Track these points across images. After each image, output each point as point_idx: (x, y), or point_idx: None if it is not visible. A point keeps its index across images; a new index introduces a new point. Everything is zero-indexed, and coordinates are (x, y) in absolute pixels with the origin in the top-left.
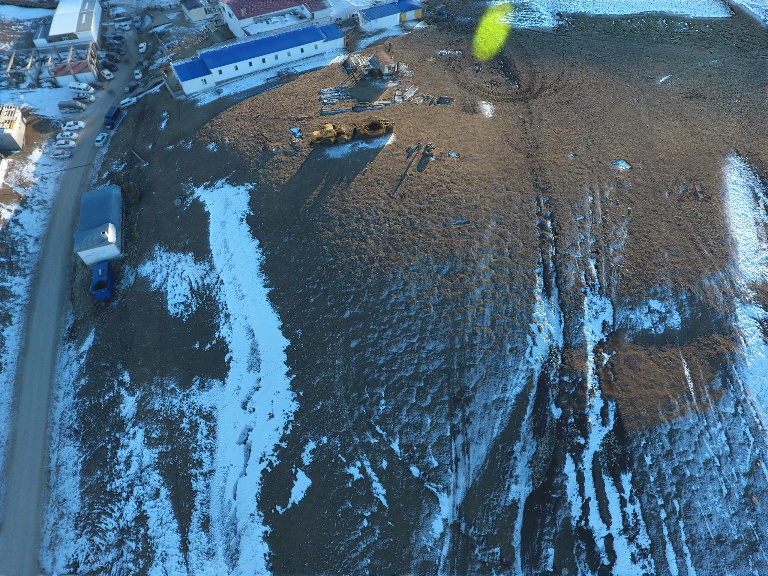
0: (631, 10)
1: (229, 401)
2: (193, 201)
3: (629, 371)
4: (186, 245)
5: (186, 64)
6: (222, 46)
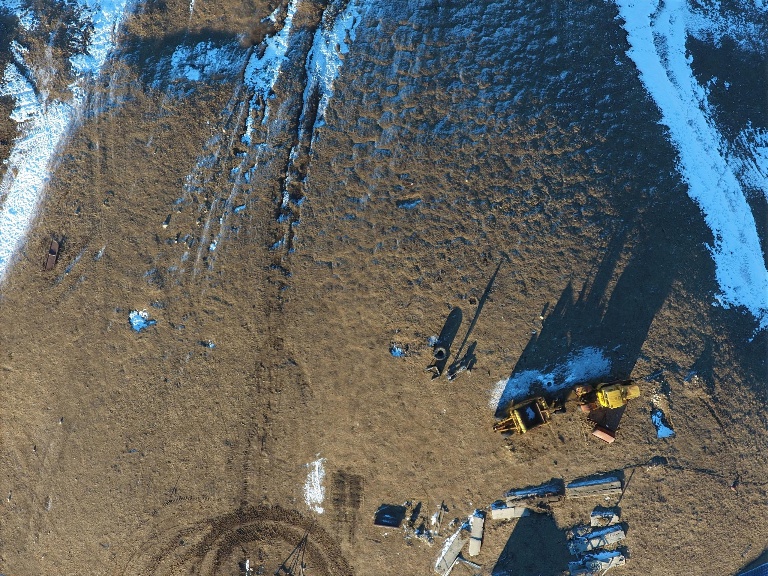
0: None
1: (678, 12)
2: None
3: None
4: None
5: None
6: None
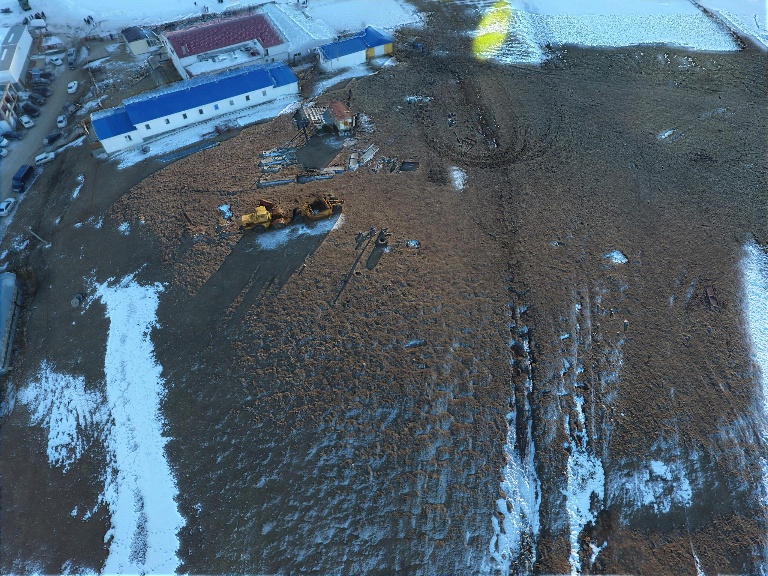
0: (629, 41)
1: None
2: (93, 302)
3: (624, 575)
4: (77, 365)
5: (107, 118)
6: (151, 95)
